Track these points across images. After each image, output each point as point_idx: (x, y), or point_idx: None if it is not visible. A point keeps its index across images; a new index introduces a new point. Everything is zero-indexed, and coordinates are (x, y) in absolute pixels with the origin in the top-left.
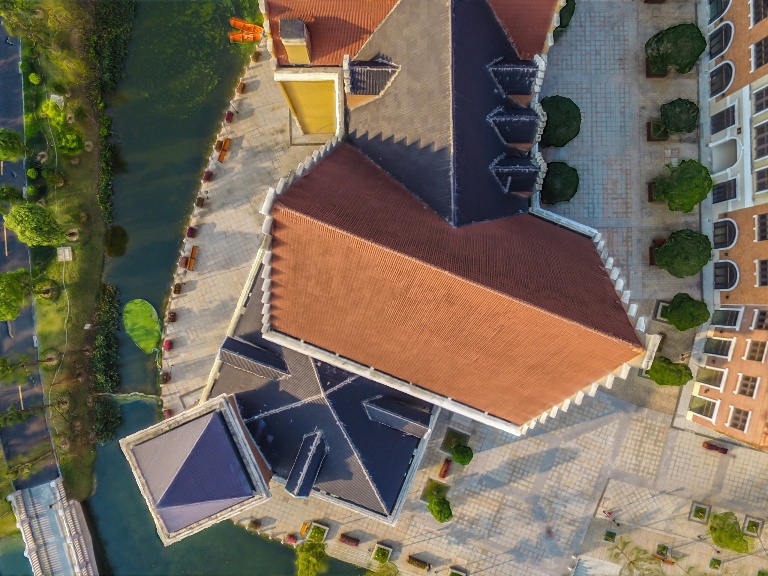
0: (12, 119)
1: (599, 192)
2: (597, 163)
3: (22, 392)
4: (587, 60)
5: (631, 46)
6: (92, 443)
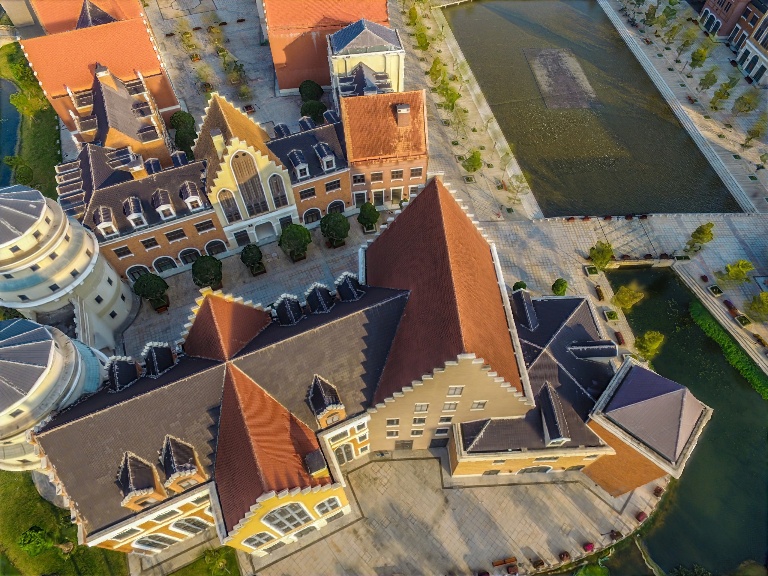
0: None
1: None
2: None
3: None
4: None
5: None
6: None
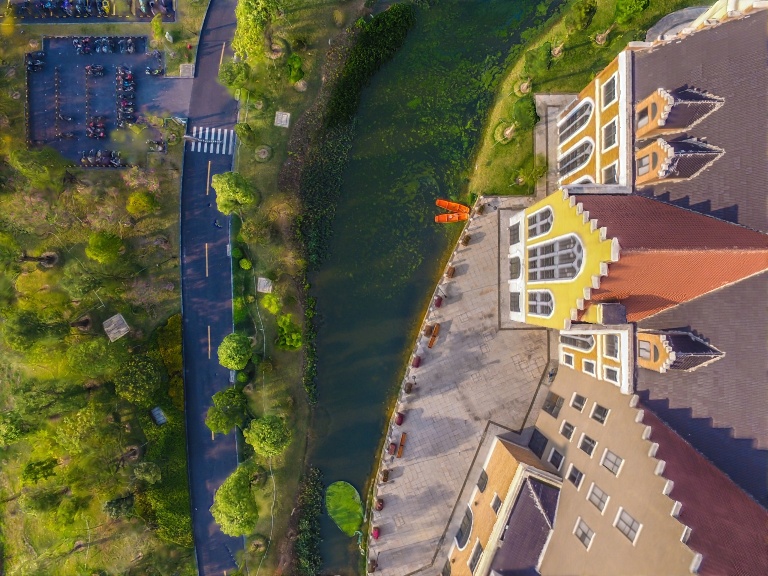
0: (220, 302)
1: None
2: None
3: None
4: None
5: None
6: None
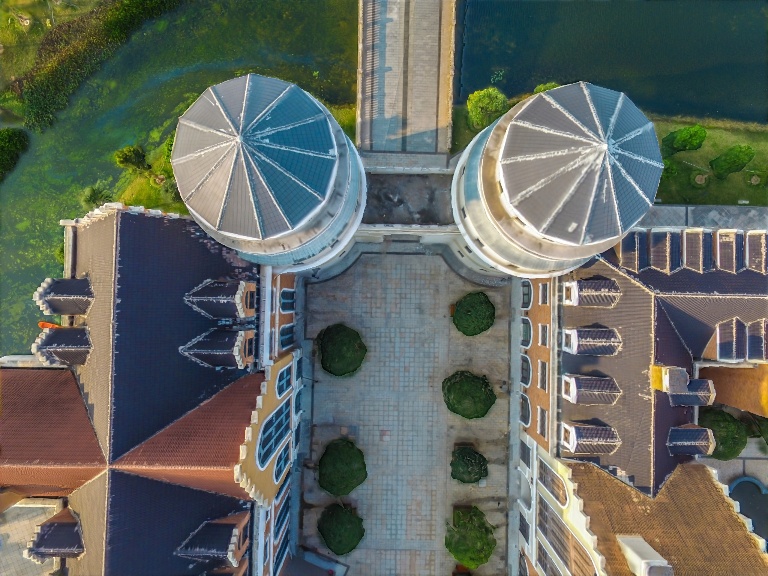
0: None
1: (403, 513)
2: (402, 483)
3: None
4: (395, 377)
5: (441, 363)
6: None
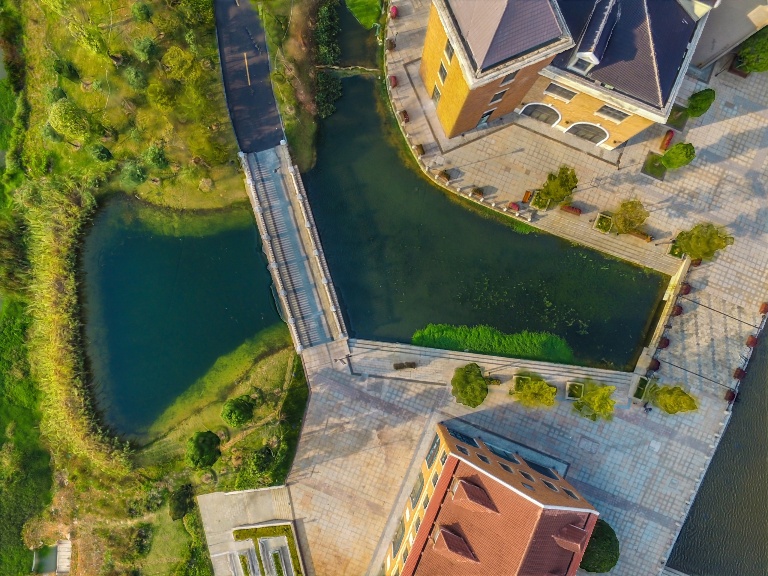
0: None
1: None
2: None
3: (247, 59)
4: None
5: None
6: (313, 114)
